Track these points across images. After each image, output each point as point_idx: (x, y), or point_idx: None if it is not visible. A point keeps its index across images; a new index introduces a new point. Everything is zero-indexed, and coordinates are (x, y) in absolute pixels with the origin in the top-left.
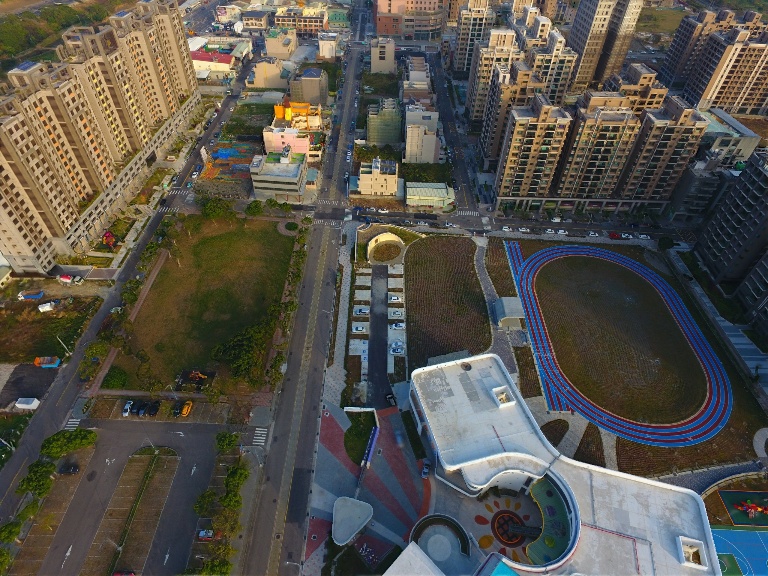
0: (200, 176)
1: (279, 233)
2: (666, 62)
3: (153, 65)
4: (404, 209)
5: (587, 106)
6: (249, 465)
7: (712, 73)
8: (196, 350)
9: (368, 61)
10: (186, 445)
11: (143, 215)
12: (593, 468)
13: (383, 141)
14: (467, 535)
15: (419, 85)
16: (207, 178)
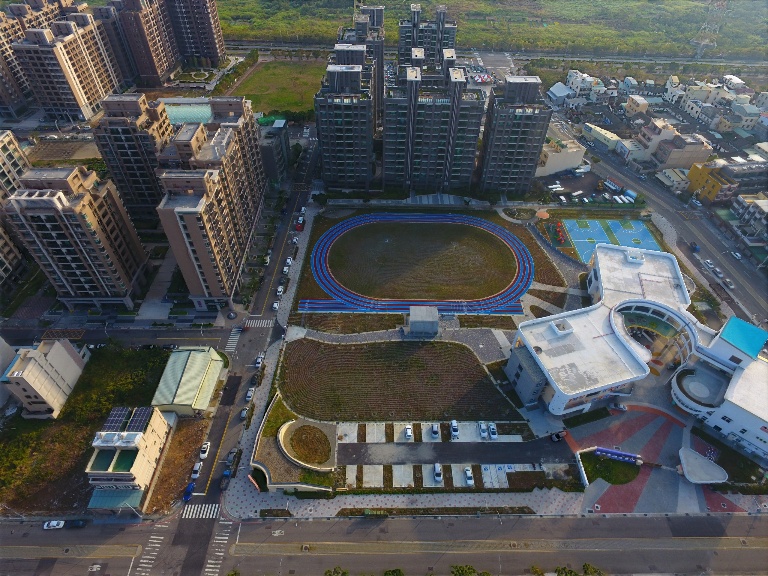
0: None
1: None
2: None
3: None
4: (205, 419)
5: (191, 153)
6: None
7: (65, 80)
8: None
9: None
10: None
11: None
12: None
13: None
14: (683, 369)
15: None
16: None
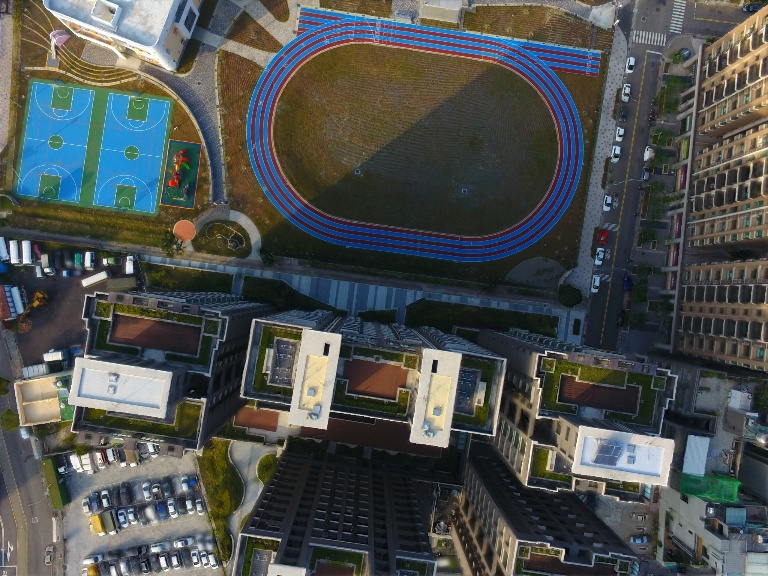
0: None
1: None
2: None
3: None
4: None
5: None
6: None
7: None
8: None
9: None
10: None
11: None
12: None
13: None
14: None
15: None
16: None
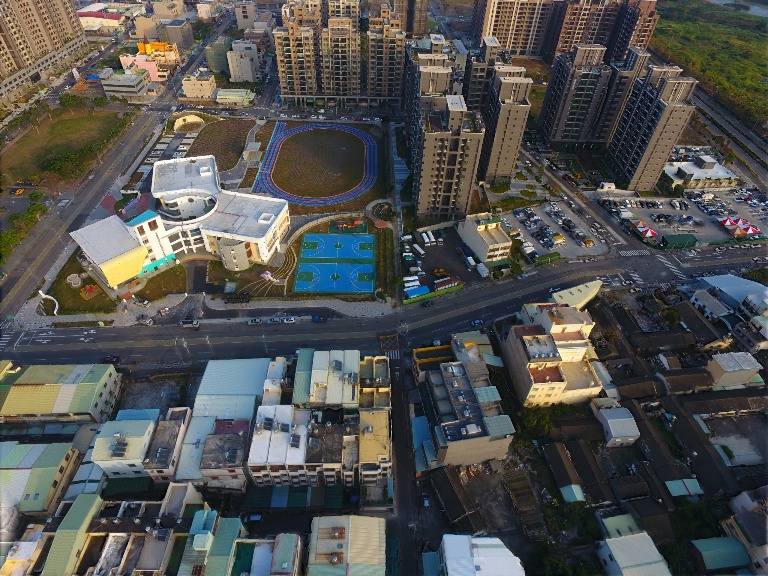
0: (71, 88)
1: (117, 118)
2: (472, 20)
3: (35, 7)
4: (216, 106)
5: None
6: (51, 213)
7: (483, 22)
8: (36, 169)
9: (234, 19)
10: (15, 206)
11: (21, 109)
12: (237, 194)
13: (220, 69)
14: None
15: (258, 31)
16: (76, 90)
